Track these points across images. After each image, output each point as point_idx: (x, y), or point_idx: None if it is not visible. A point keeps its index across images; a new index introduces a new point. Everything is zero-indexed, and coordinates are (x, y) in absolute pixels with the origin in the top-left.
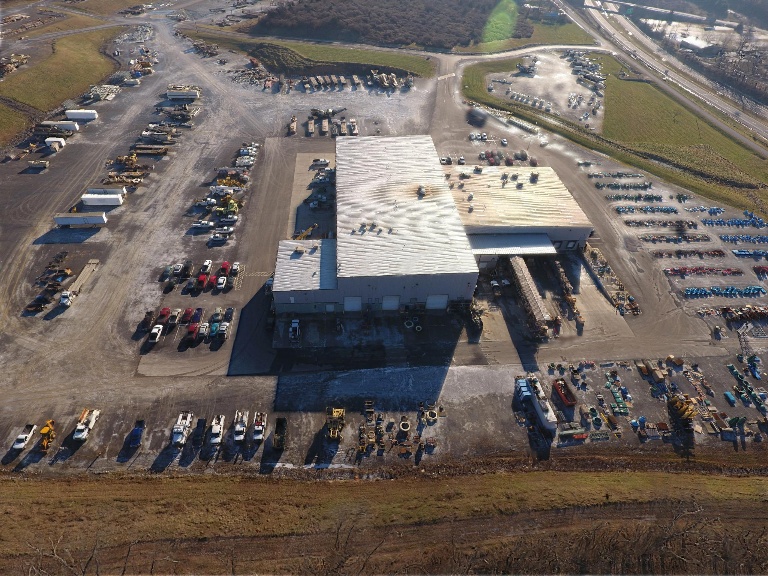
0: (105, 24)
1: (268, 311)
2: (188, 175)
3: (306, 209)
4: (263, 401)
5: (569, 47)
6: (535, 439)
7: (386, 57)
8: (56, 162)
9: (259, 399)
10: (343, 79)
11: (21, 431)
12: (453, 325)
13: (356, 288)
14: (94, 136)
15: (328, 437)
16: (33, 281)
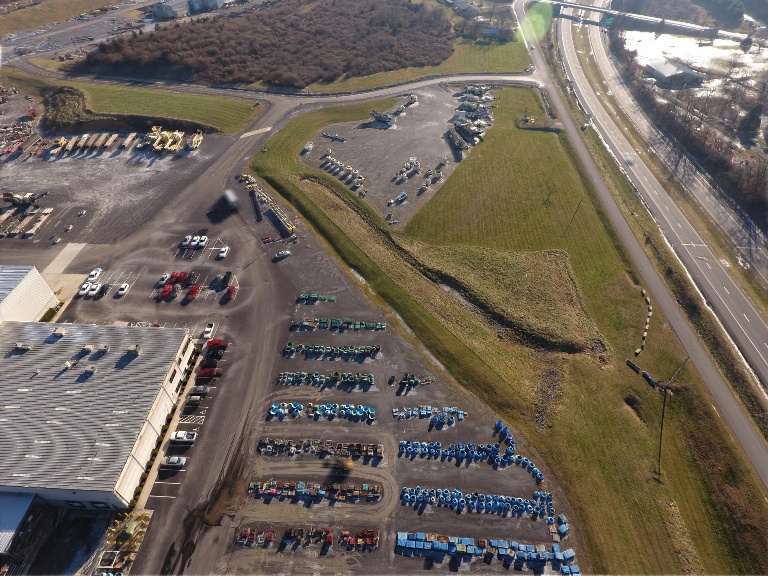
0: None
1: None
2: None
3: None
4: None
5: (481, 78)
6: None
7: (196, 105)
8: None
9: None
10: (112, 139)
11: None
12: None
13: None
14: None
15: None
16: None
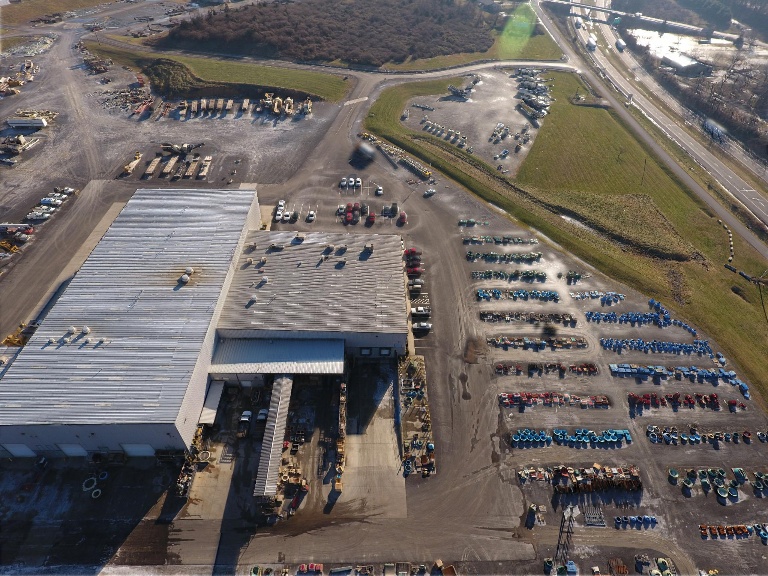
0: (4, 35)
1: None
2: None
3: None
4: None
5: (527, 64)
6: None
7: (294, 77)
8: None
9: None
10: (230, 104)
11: None
12: (152, 487)
13: (8, 436)
14: None
15: None
16: None
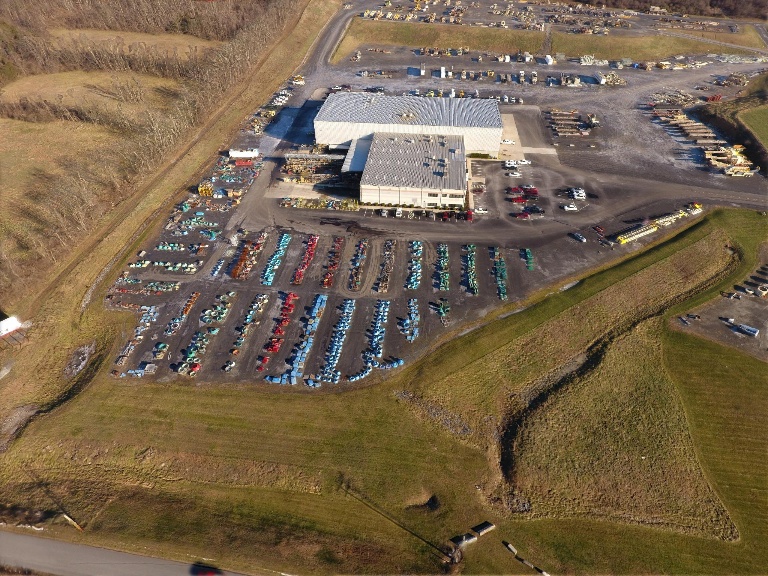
0: (751, 47)
1: None
2: (476, 88)
3: None
4: None
5: None
6: None
7: None
8: None
9: (291, 105)
10: (704, 134)
11: None
12: None
13: None
14: (522, 66)
15: None
16: None
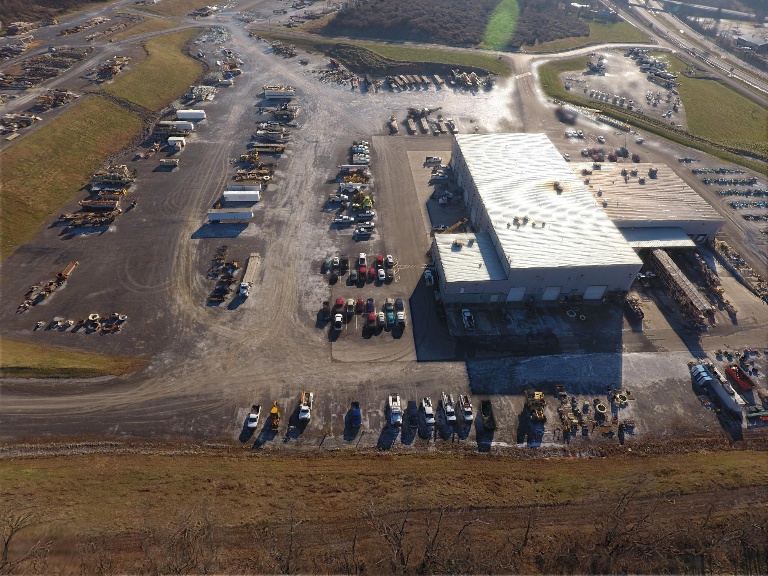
0: (180, 26)
1: (434, 301)
2: (311, 172)
3: (435, 205)
4: (459, 385)
5: (629, 45)
6: (725, 421)
7: (461, 56)
8: (183, 160)
9: (455, 383)
10: (426, 78)
11: (247, 411)
12: (613, 314)
13: (524, 279)
14: (209, 135)
15: (535, 418)
16: (205, 273)
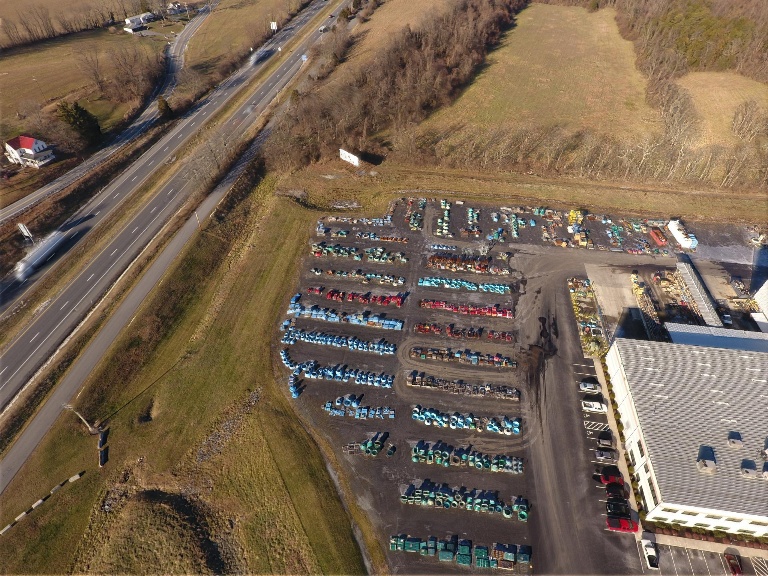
0: None
1: None
2: None
3: None
4: None
5: None
6: None
7: None
8: None
9: None
10: None
11: None
12: None
13: None
14: None
15: None
16: None
